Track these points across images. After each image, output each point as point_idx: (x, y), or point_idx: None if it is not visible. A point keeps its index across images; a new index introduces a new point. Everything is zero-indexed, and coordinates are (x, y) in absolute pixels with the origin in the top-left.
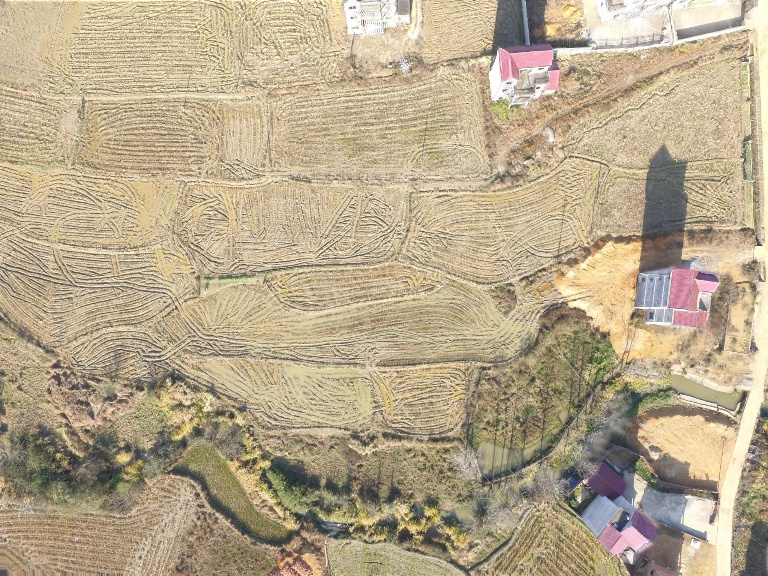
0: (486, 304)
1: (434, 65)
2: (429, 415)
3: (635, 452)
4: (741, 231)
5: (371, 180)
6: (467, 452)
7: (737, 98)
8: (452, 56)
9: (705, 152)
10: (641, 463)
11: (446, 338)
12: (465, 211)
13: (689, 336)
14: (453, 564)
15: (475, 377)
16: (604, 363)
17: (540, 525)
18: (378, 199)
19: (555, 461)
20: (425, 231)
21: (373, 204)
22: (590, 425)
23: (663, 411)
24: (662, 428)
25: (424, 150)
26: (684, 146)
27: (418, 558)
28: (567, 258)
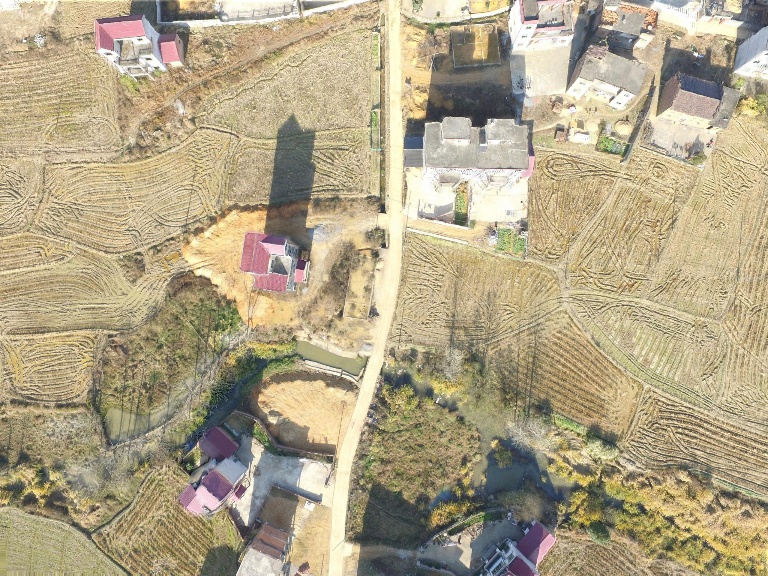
0: (115, 273)
1: (70, 39)
2: (57, 382)
3: (254, 416)
4: (366, 199)
5: (5, 153)
6: (93, 418)
7: (367, 68)
8: (89, 30)
9: (334, 121)
10: (259, 427)
11: (75, 307)
12: (97, 182)
13: (310, 302)
14: (76, 527)
15: (103, 344)
16: (228, 330)
17: (161, 488)
18: (13, 171)
19: (179, 426)
20: (58, 202)
21: (8, 176)
22: (212, 390)
23: (287, 376)
24: (283, 393)
25: (58, 123)
26: (313, 116)
27: (42, 521)
28: (195, 227)
